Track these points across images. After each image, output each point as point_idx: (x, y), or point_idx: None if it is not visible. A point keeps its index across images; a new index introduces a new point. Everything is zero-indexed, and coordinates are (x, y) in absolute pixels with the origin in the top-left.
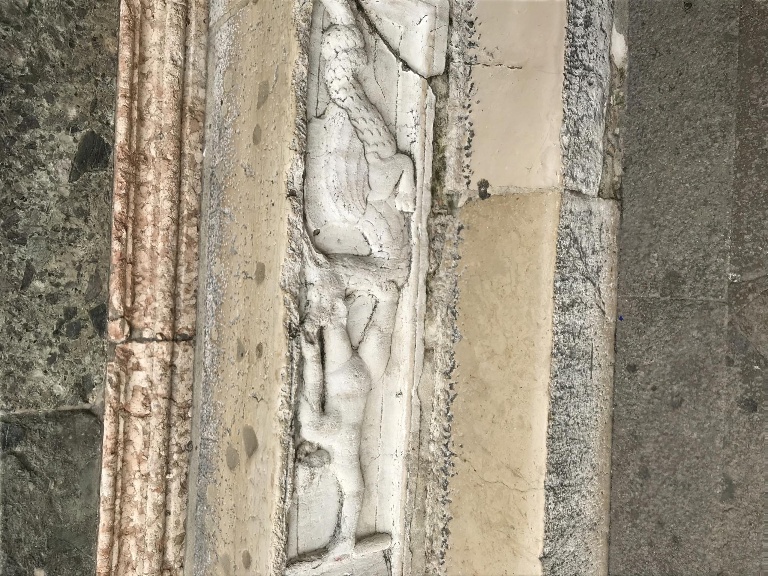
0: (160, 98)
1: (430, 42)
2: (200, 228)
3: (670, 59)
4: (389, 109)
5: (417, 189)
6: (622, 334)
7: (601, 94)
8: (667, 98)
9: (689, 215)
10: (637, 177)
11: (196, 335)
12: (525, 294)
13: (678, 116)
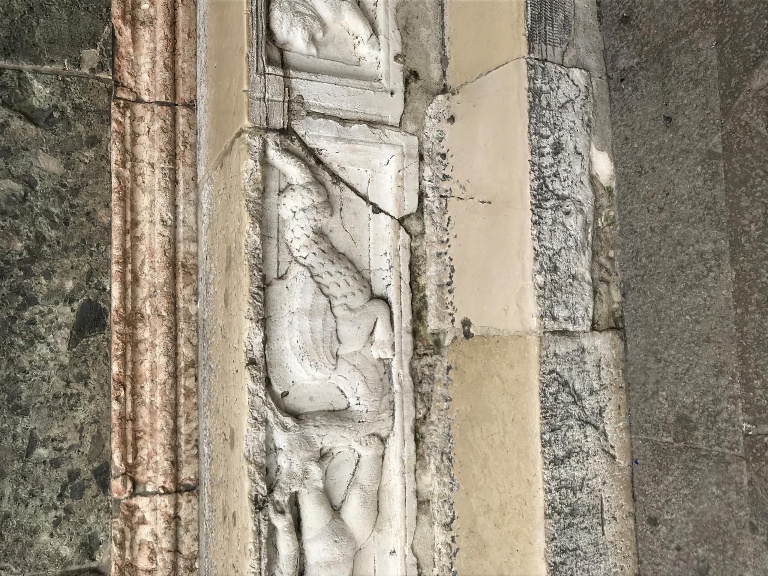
0: (153, 258)
1: (399, 182)
2: (198, 377)
3: (655, 178)
4: (361, 254)
5: (395, 334)
6: (639, 480)
7: (582, 221)
8: (657, 220)
9: (693, 352)
10: (637, 304)
11: (199, 484)
12: (513, 446)
13: (670, 240)
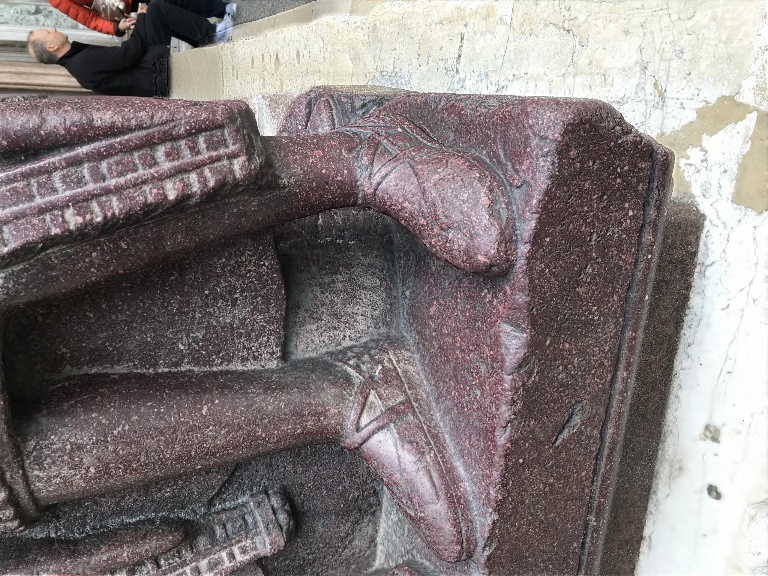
0: None
1: None
2: None
3: None
4: None
5: None
6: None
7: None
8: None
9: None
10: None
11: None
12: None
13: None
